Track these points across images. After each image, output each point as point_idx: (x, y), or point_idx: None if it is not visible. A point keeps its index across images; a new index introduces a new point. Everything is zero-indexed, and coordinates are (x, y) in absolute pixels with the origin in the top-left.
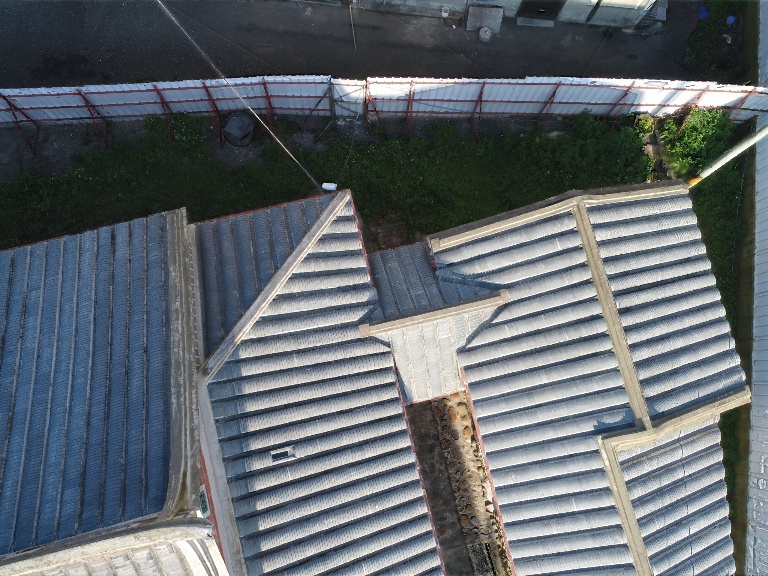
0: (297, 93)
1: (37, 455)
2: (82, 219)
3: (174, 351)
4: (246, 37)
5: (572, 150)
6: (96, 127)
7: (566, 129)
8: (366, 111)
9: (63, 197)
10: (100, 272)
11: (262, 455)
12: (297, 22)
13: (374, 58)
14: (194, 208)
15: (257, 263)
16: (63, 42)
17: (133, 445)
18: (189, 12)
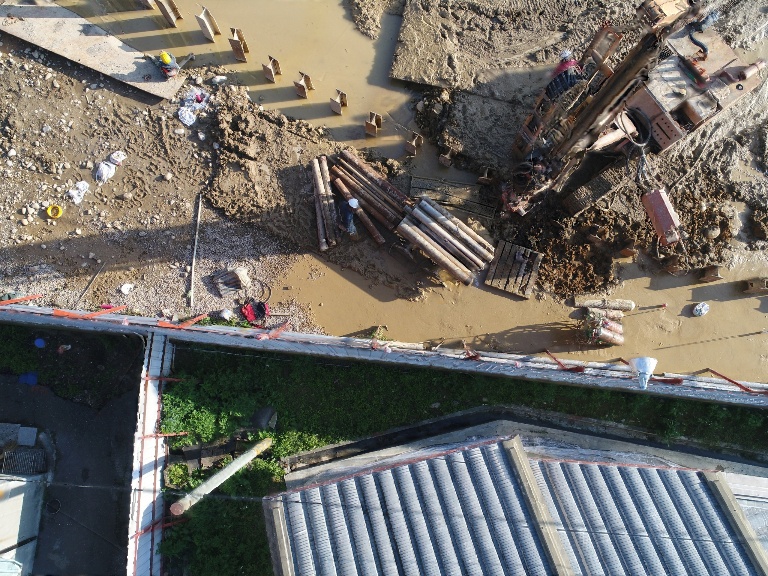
0: None
1: None
2: None
3: None
4: None
5: (209, 569)
6: None
7: (180, 567)
8: None
9: None
10: None
11: None
12: None
13: None
14: None
15: None
16: None
17: None
18: None
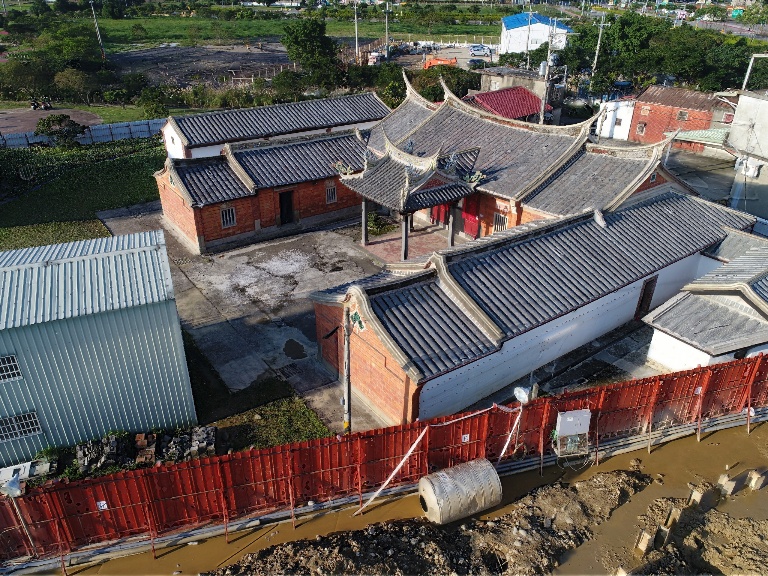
0: (765, 233)
1: None
2: None
3: None
4: None
5: None
6: None
7: None
8: None
9: None
10: None
11: (665, 205)
12: None
13: None
14: None
15: None
16: None
17: None
18: None
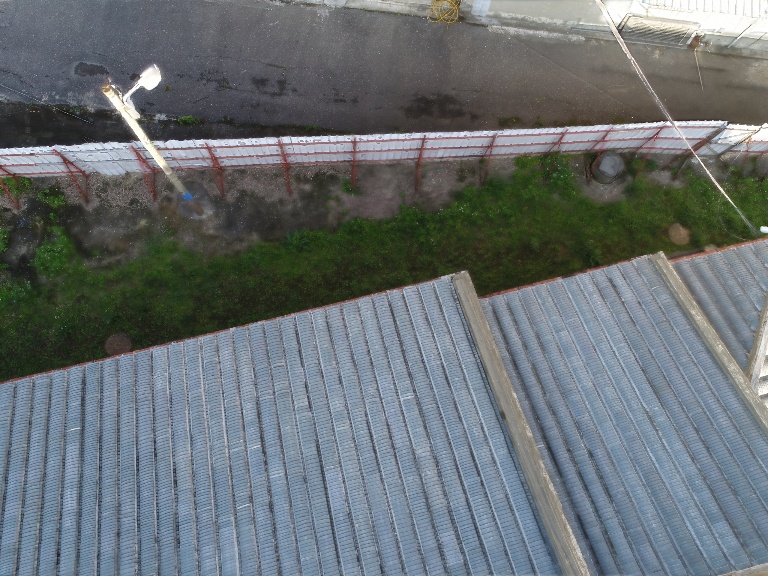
0: (678, 135)
1: (661, 490)
2: (464, 252)
3: (747, 393)
4: (601, 78)
5: None
6: (469, 164)
7: None
8: (727, 151)
9: (447, 231)
10: (619, 314)
11: None
12: (647, 64)
13: (721, 99)
14: (566, 242)
15: (734, 304)
16: (432, 82)
17: (761, 482)
18: (546, 54)
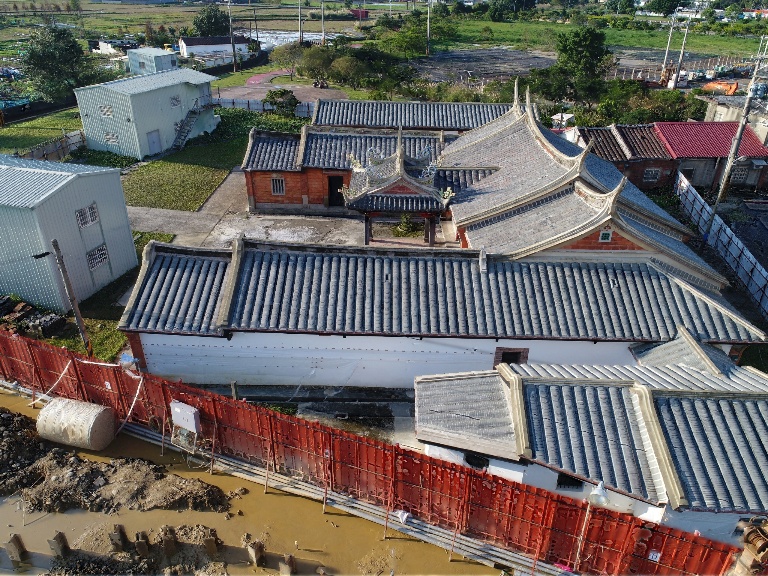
0: None
1: None
2: None
3: None
4: None
5: None
6: (767, 325)
7: None
8: None
9: None
10: None
11: None
12: None
13: None
14: None
15: None
16: None
17: None
18: None
